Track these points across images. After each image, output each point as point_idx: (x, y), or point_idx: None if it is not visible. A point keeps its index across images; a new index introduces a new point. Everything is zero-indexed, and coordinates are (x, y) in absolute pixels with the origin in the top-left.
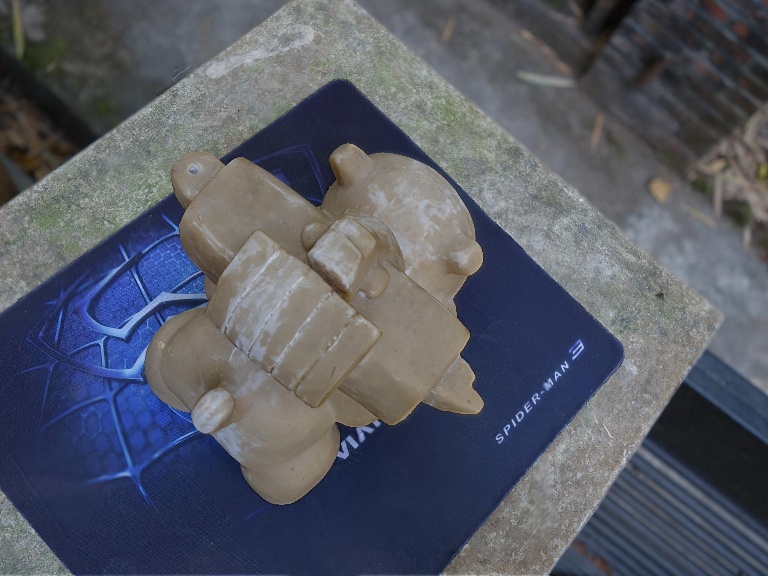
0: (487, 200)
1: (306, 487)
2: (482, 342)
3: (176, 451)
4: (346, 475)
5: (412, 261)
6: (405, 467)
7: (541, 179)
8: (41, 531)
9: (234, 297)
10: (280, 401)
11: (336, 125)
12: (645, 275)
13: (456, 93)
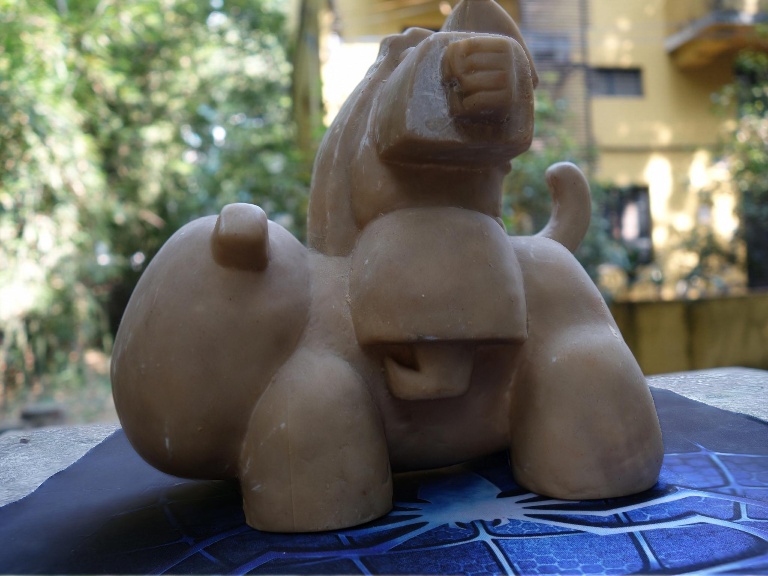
0: None
1: None
2: None
3: None
4: None
5: None
6: None
7: None
8: None
9: None
10: None
11: None
12: (3, 451)
13: None
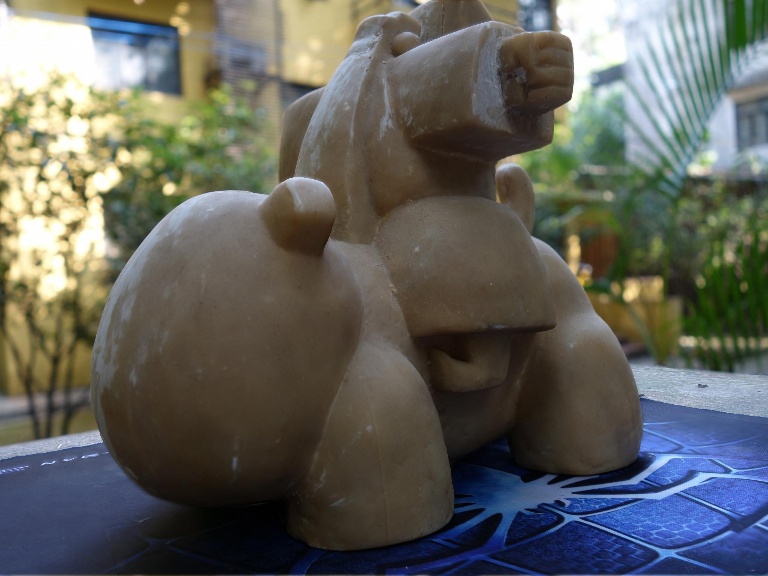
0: None
1: None
2: None
3: None
4: None
5: None
6: None
7: None
8: None
9: None
10: None
11: None
12: None
13: None
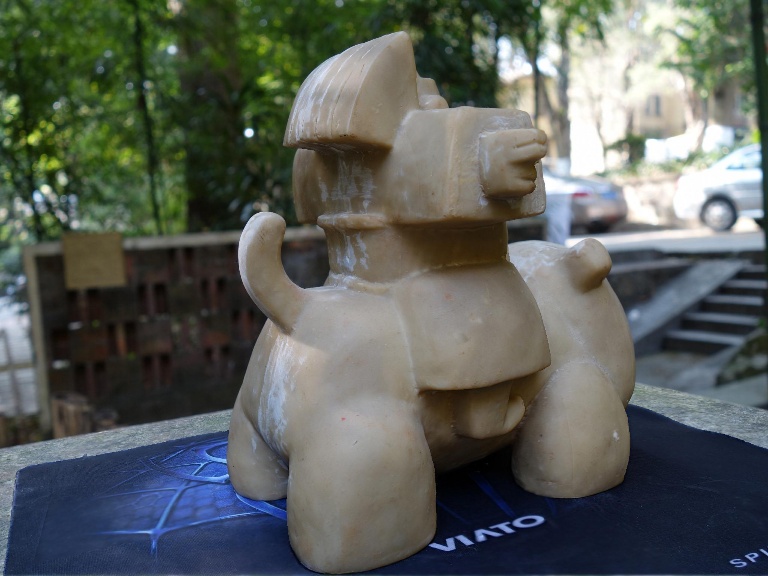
0: (690, 425)
1: (361, 476)
2: (691, 490)
3: (220, 523)
4: (443, 563)
5: (527, 271)
6: (548, 567)
7: (766, 417)
8: (12, 558)
9: None
10: (341, 298)
11: None
12: None
13: (646, 385)
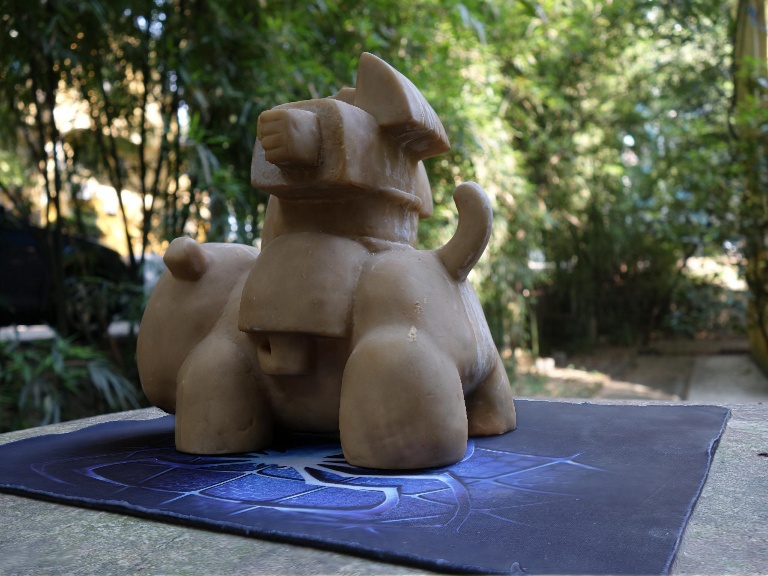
0: None
1: None
2: None
3: None
4: None
5: None
6: None
7: (104, 418)
8: None
9: (406, 81)
10: None
11: (0, 459)
12: None
13: None
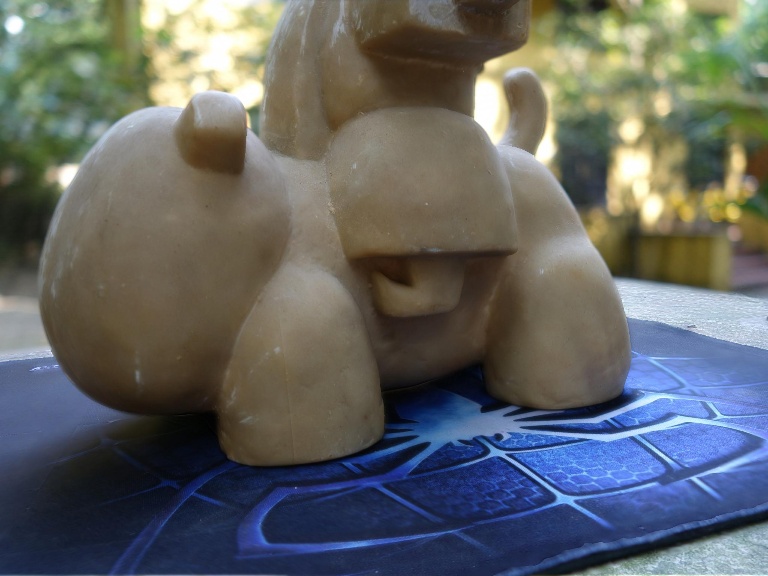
0: None
1: None
2: None
3: None
4: None
5: None
6: None
7: None
8: None
9: None
10: None
11: None
12: None
13: None
